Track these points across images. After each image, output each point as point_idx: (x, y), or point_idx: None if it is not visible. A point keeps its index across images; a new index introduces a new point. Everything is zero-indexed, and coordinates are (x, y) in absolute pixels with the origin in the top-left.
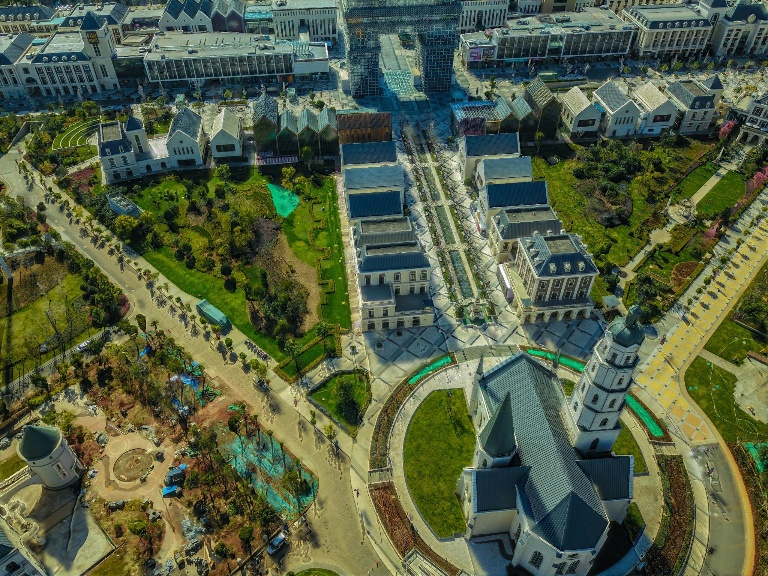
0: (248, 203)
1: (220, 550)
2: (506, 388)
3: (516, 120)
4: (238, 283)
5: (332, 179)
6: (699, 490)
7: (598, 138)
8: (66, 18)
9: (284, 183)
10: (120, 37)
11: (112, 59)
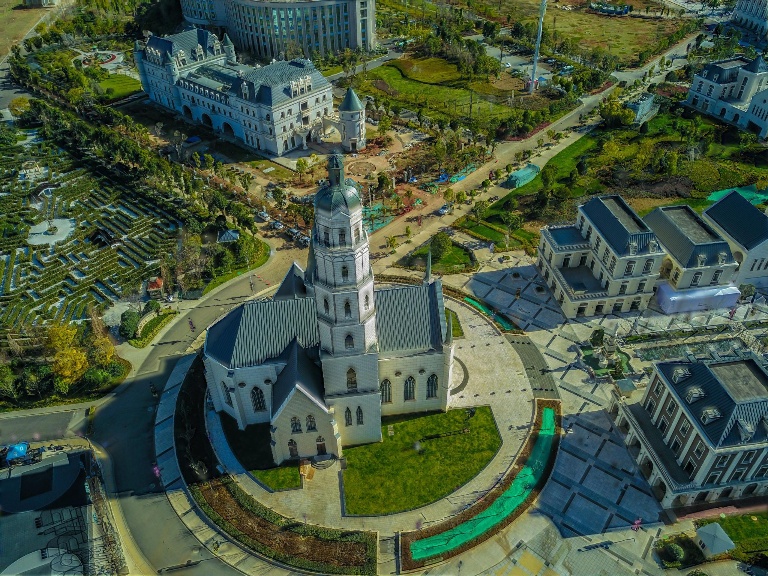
0: (693, 158)
1: (275, 190)
2: None
3: None
4: None
5: None
6: None
7: None
8: None
9: (760, 177)
10: None
11: None
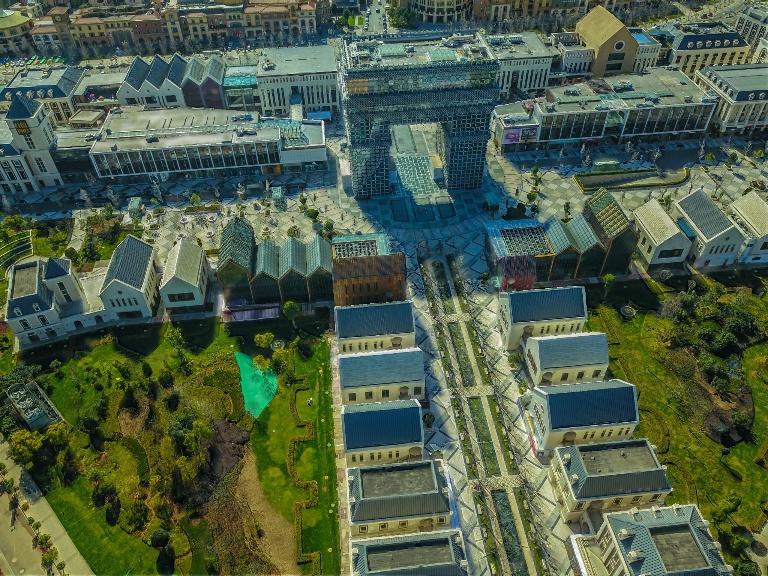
0: (202, 405)
1: None
2: None
3: (576, 253)
4: (178, 558)
5: (324, 344)
6: None
7: (690, 280)
8: (2, 90)
9: (256, 363)
10: (70, 111)
11: (50, 151)
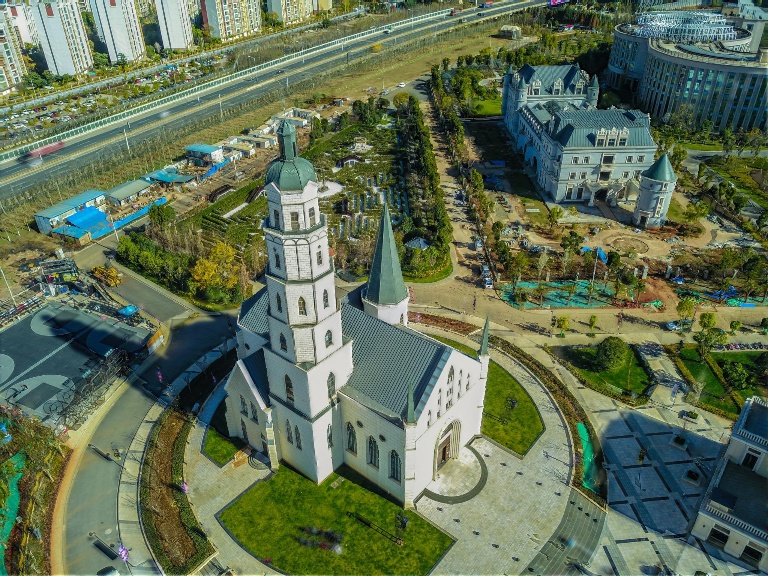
0: None
1: (496, 222)
2: None
3: None
4: None
5: None
6: (136, 549)
7: None
8: None
9: None
10: None
11: None
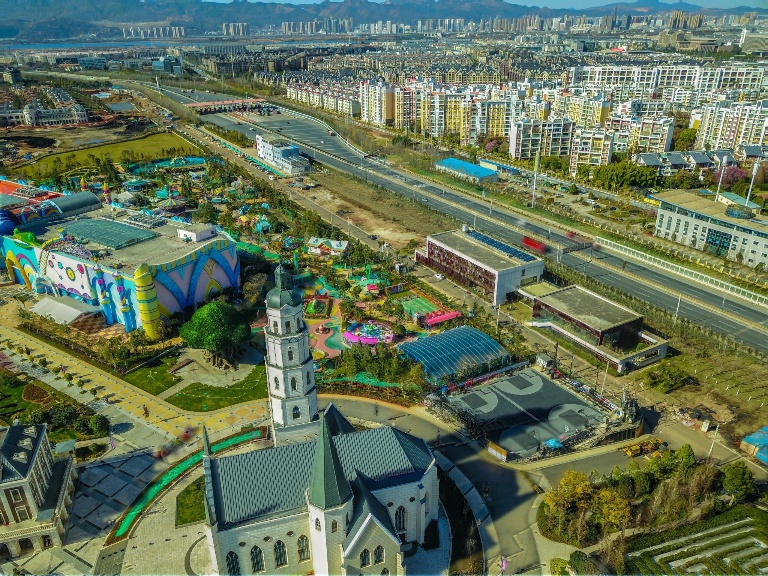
0: None
1: None
2: (245, 491)
3: None
4: None
5: None
6: None
7: None
8: None
9: None
10: None
11: None
